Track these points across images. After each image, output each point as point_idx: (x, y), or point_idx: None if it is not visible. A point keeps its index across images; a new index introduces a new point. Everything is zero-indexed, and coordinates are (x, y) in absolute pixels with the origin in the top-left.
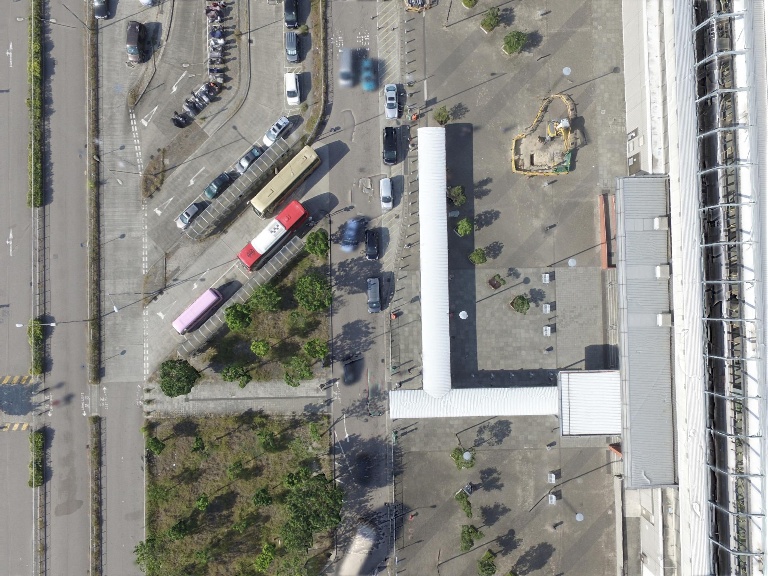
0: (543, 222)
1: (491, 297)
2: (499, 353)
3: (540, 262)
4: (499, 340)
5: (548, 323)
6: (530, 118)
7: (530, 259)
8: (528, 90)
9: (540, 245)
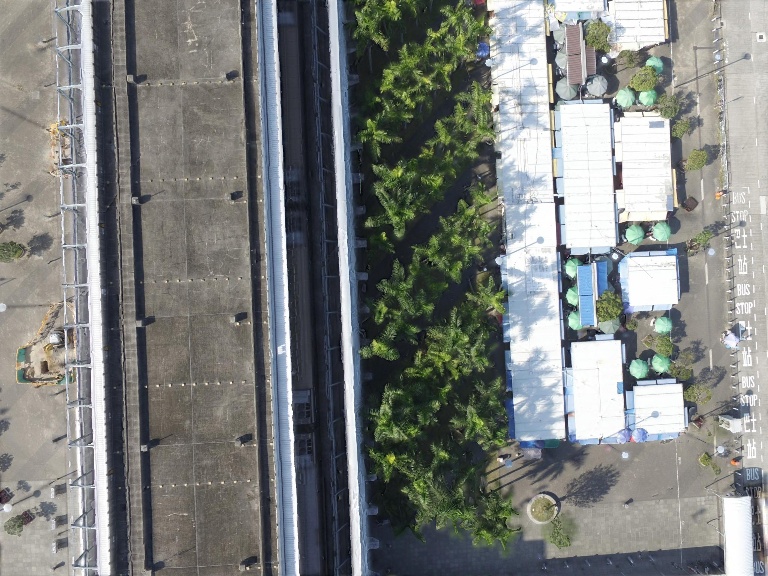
0: (54, 432)
1: (0, 512)
2: (9, 570)
3: (51, 474)
4: (9, 556)
5: (59, 537)
6: (40, 324)
7: (41, 471)
8: (38, 295)
9: (51, 456)
